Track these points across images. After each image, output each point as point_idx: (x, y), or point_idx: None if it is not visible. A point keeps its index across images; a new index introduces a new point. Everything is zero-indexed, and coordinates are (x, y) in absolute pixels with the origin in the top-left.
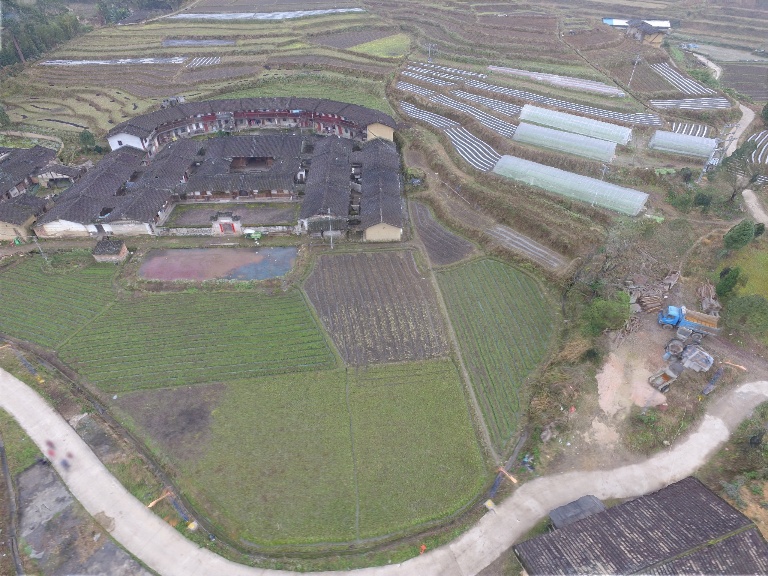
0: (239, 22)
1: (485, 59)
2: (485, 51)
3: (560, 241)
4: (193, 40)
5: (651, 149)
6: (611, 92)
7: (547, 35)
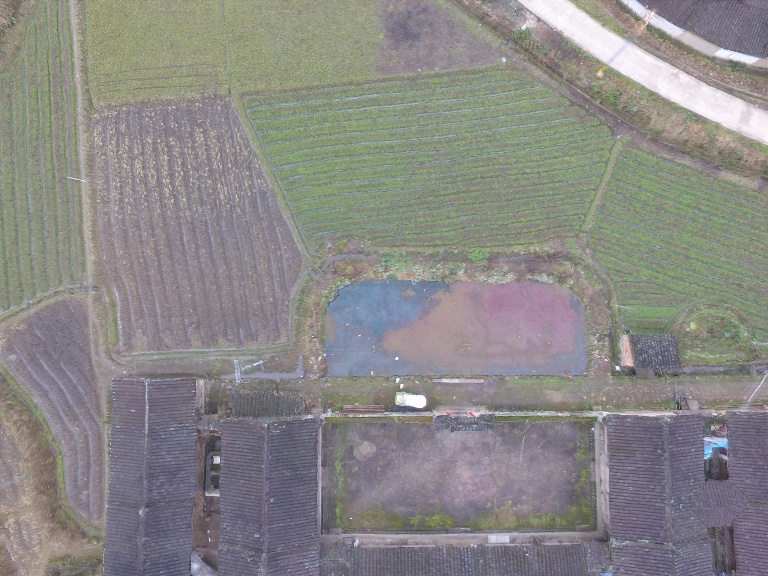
0: None
1: None
2: None
3: None
4: None
5: None
6: None
7: None
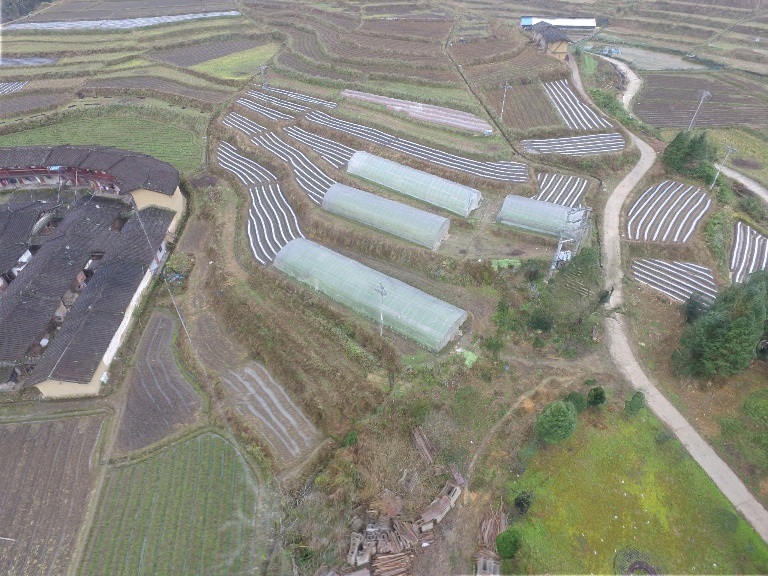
0: (79, 33)
1: (341, 81)
2: (346, 69)
3: (314, 404)
4: (8, 59)
5: (498, 224)
6: (476, 129)
7: (432, 45)
